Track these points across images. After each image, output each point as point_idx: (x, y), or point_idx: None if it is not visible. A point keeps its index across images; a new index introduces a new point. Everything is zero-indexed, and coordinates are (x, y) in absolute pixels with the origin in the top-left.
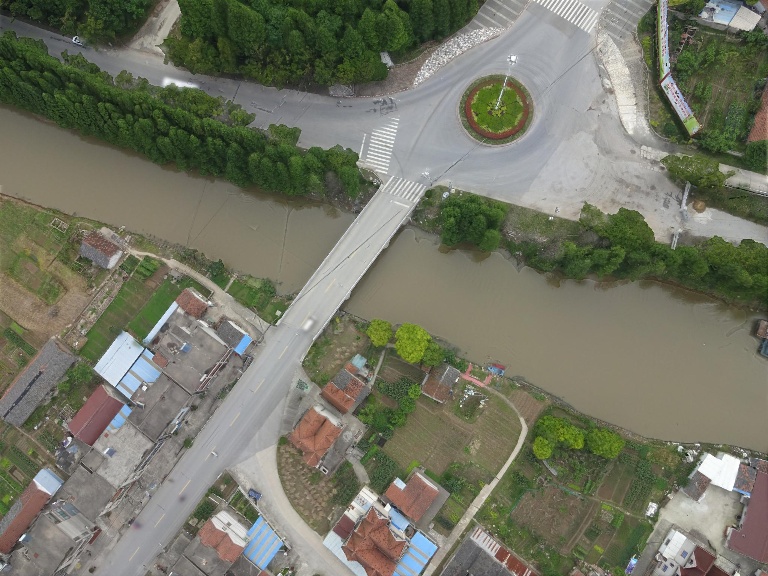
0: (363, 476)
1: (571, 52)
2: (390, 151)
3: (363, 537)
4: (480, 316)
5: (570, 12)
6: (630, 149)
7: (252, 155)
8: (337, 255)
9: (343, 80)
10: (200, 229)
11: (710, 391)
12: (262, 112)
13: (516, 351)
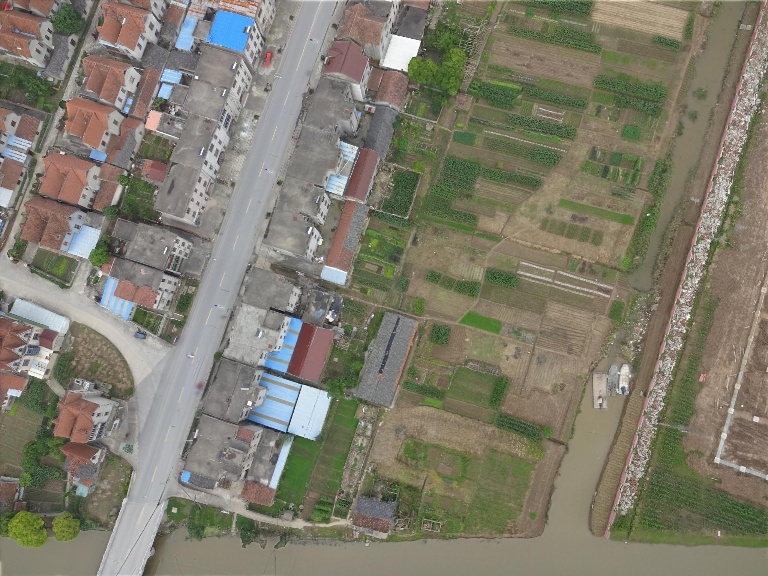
0: (54, 385)
1: None
2: None
3: (5, 347)
4: (7, 564)
5: None
6: None
7: None
8: None
9: None
10: None
11: None
12: None
13: None
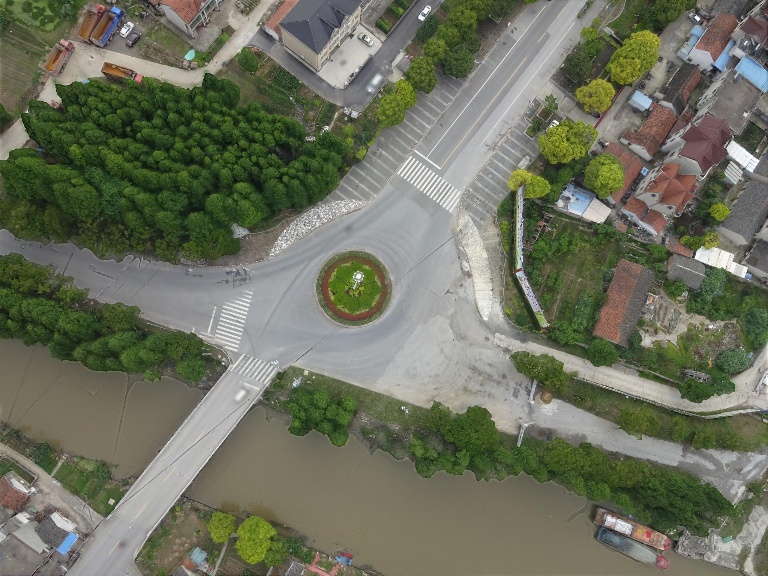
0: None
1: (432, 231)
2: (241, 327)
3: None
4: (333, 492)
5: (433, 189)
6: (484, 336)
7: (76, 354)
8: (178, 441)
9: (189, 258)
10: (21, 413)
11: (552, 569)
12: (101, 277)
13: (366, 535)
